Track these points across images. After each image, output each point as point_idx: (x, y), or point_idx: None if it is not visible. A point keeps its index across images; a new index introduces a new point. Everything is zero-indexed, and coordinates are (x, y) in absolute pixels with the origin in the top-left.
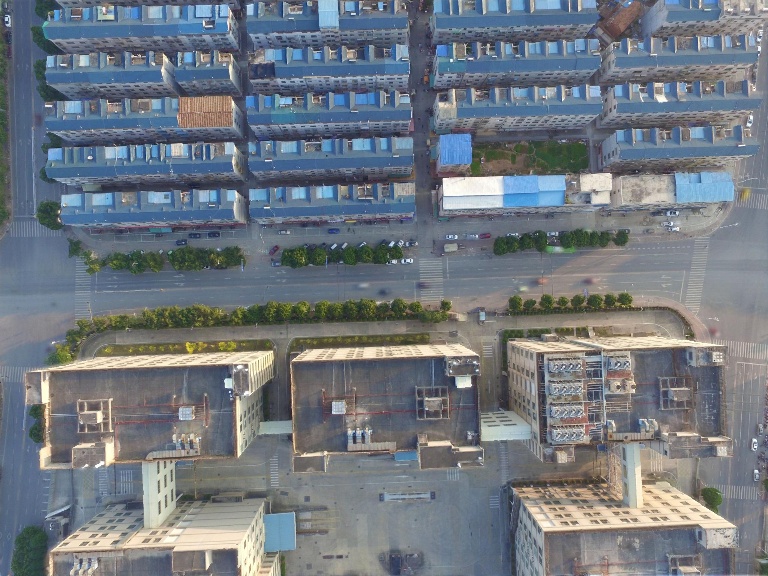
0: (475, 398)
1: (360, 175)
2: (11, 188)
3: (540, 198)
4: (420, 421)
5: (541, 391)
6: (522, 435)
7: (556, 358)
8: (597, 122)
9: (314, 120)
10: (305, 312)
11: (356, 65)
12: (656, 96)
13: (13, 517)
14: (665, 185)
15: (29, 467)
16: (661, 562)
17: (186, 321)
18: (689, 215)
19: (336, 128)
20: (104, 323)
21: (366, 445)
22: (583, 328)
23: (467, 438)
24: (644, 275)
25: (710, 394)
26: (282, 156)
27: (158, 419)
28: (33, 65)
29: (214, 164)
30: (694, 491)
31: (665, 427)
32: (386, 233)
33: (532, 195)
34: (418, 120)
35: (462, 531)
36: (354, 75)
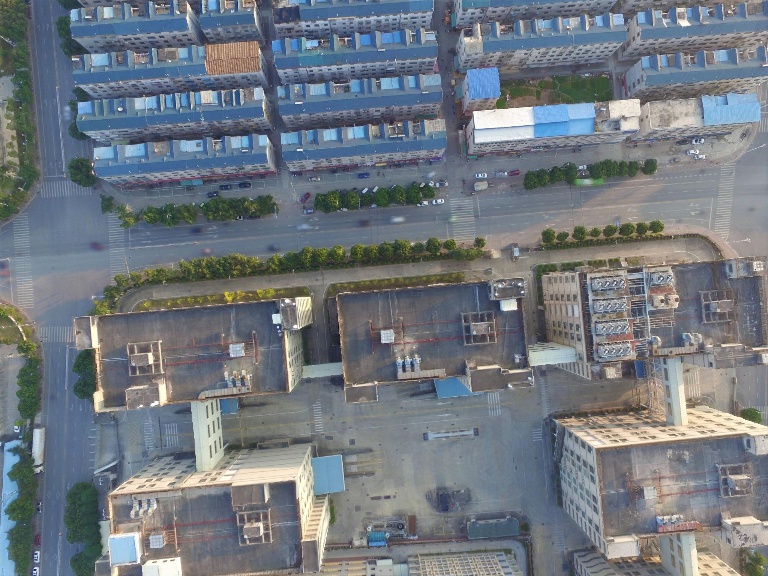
0: (520, 321)
1: (388, 117)
2: (39, 149)
3: (570, 127)
4: (467, 347)
5: (586, 310)
6: (567, 358)
7: (599, 277)
8: (619, 54)
9: (341, 61)
10: (341, 255)
11: (380, 4)
12: (679, 21)
13: (61, 476)
14: (692, 109)
15: (74, 426)
16: (711, 472)
17: (223, 270)
18: (714, 142)
19: (362, 70)
20: (141, 278)
21: (416, 373)
22: (615, 259)
23: (514, 361)
24: (673, 204)
25: (751, 306)
26: (312, 98)
27: (208, 359)
28: (55, 22)
29: (244, 109)
30: (732, 414)
31: (708, 340)
32: (416, 175)
33: (562, 124)
34: (441, 61)
35: (507, 465)
36: (379, 14)
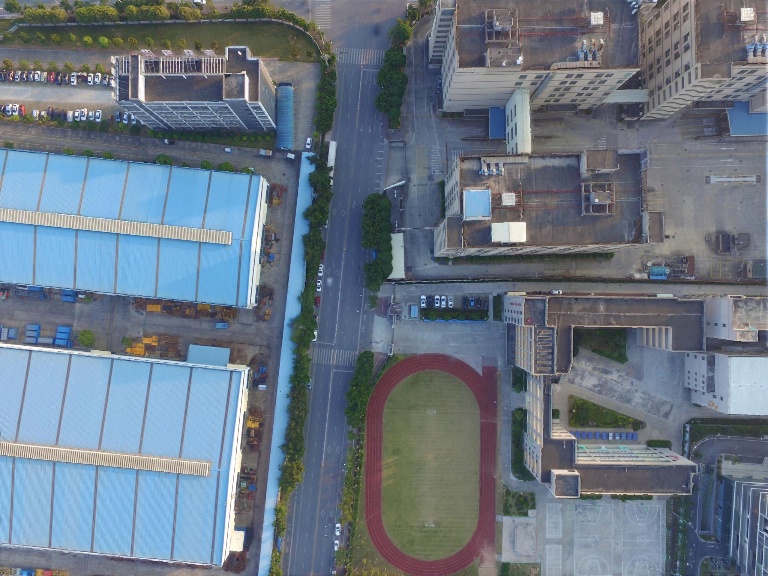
0: None
1: None
2: None
3: None
4: None
5: None
6: None
7: None
8: None
9: None
10: None
11: None
12: None
13: (346, 195)
14: None
15: (362, 146)
16: None
17: None
18: None
19: None
20: None
21: (766, 58)
22: None
23: None
24: None
25: None
26: None
27: (561, 32)
28: None
29: None
30: None
31: None
32: None
33: None
34: None
35: None
36: None
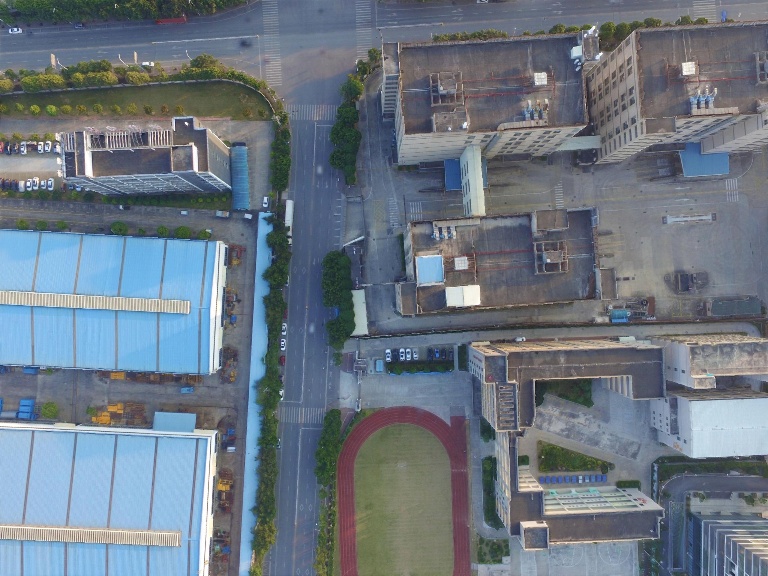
0: None
1: None
2: None
3: None
4: (759, 87)
5: None
6: None
7: None
8: None
9: None
10: None
11: None
12: None
13: (306, 252)
14: None
15: (320, 202)
16: None
17: None
18: None
19: None
20: None
21: (710, 110)
22: None
23: None
24: None
25: None
26: None
27: (506, 92)
28: None
29: None
30: None
31: None
32: None
33: None
34: None
35: (744, 250)
36: None
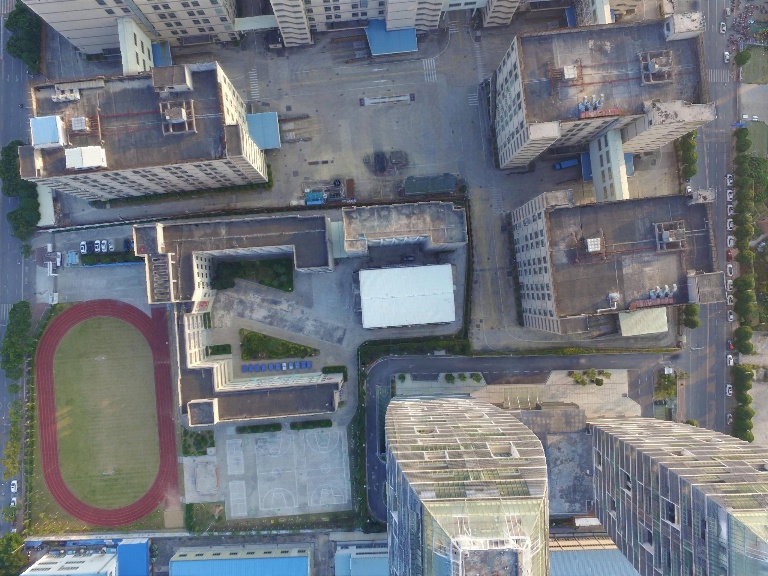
0: None
1: None
2: None
3: None
4: None
5: None
6: None
7: None
8: None
9: None
10: None
11: None
12: None
13: None
14: None
15: (10, 96)
16: (633, 62)
17: None
18: None
19: None
20: None
21: None
22: None
23: None
24: None
25: None
26: None
27: None
28: None
29: None
30: None
31: None
32: None
33: None
34: None
35: (443, 130)
36: None
